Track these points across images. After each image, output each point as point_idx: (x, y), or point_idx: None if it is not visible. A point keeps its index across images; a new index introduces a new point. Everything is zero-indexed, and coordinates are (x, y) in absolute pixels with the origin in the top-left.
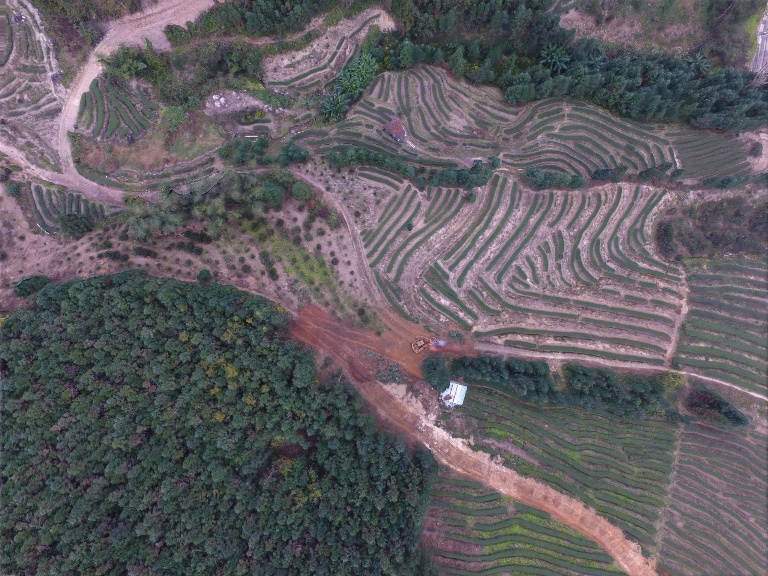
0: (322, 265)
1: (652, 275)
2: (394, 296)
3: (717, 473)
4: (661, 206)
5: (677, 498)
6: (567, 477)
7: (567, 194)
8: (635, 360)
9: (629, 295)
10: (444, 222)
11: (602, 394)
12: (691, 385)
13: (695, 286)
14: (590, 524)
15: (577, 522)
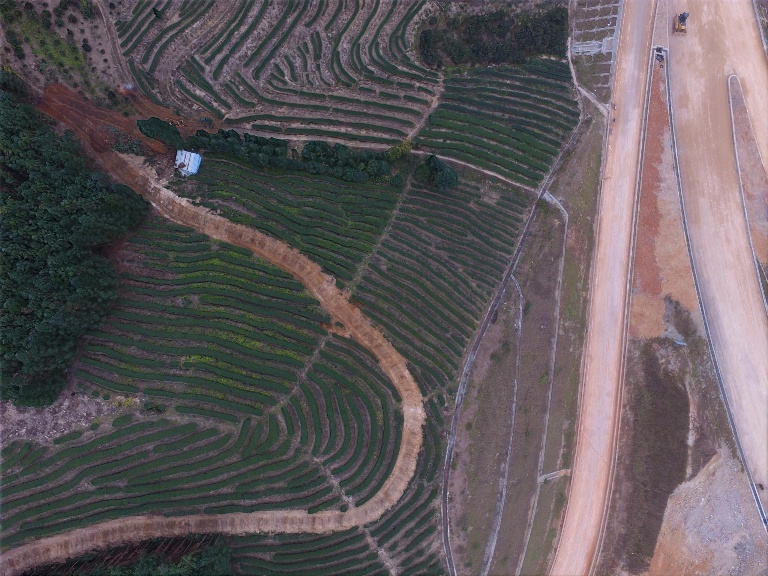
0: (72, 49)
1: (412, 78)
2: (147, 84)
3: (432, 229)
4: (422, 15)
5: (385, 246)
6: (280, 226)
7: None
8: (375, 142)
9: (383, 92)
10: (198, 15)
11: (329, 160)
12: None
13: (449, 86)
14: (291, 261)
15: (280, 260)
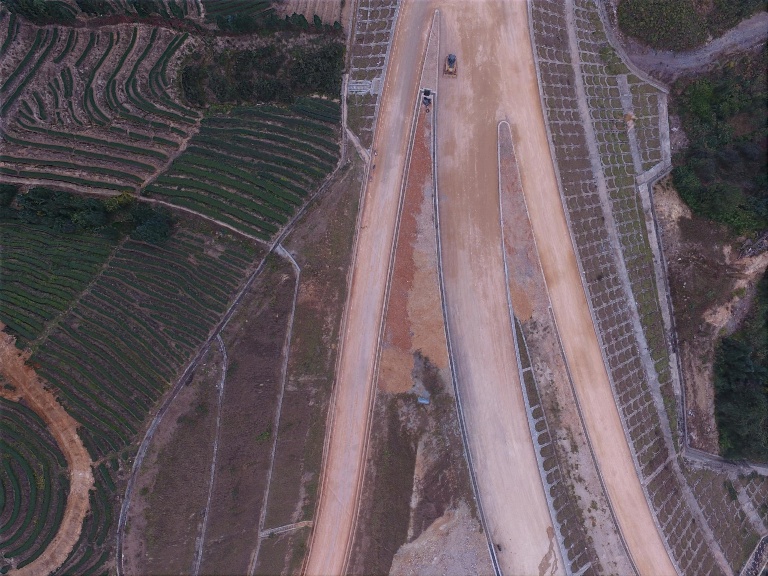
0: None
1: (170, 117)
2: None
3: (139, 285)
4: (185, 50)
5: (83, 303)
6: None
7: (73, 30)
8: (109, 188)
9: (133, 132)
10: None
11: None
12: (156, 211)
13: (204, 127)
14: None
15: None
